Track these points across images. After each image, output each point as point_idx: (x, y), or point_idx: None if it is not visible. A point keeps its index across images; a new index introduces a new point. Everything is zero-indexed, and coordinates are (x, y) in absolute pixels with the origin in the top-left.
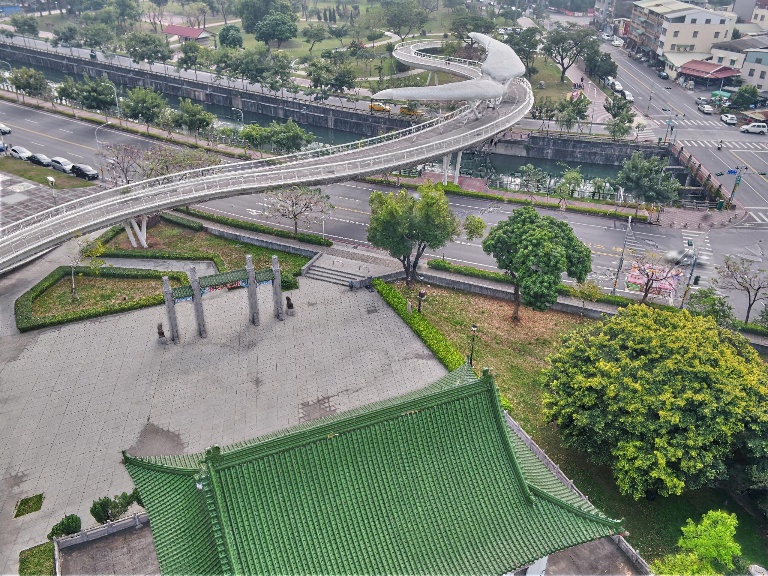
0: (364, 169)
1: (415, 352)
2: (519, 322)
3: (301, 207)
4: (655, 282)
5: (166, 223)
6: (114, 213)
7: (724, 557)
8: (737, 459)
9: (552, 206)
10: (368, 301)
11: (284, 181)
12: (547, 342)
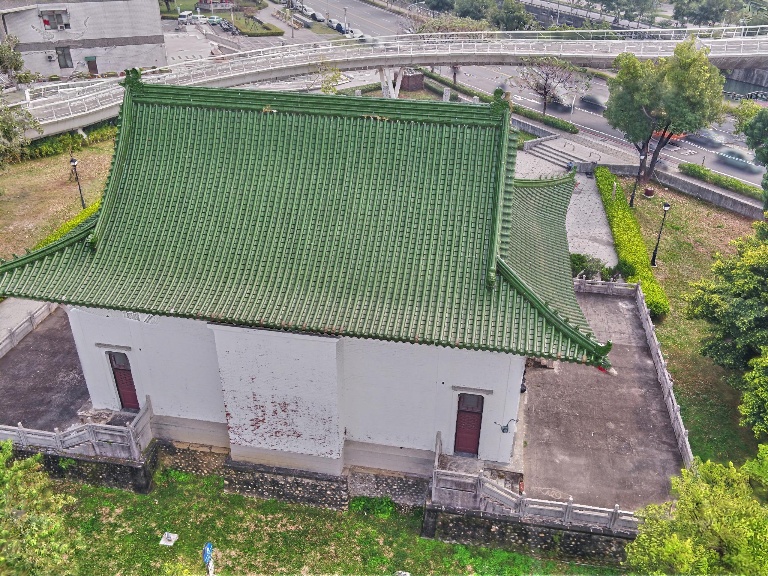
0: (648, 54)
1: (592, 234)
2: None
3: (555, 83)
4: None
5: (428, 91)
6: (368, 55)
7: None
8: None
9: None
10: None
11: (546, 52)
12: None
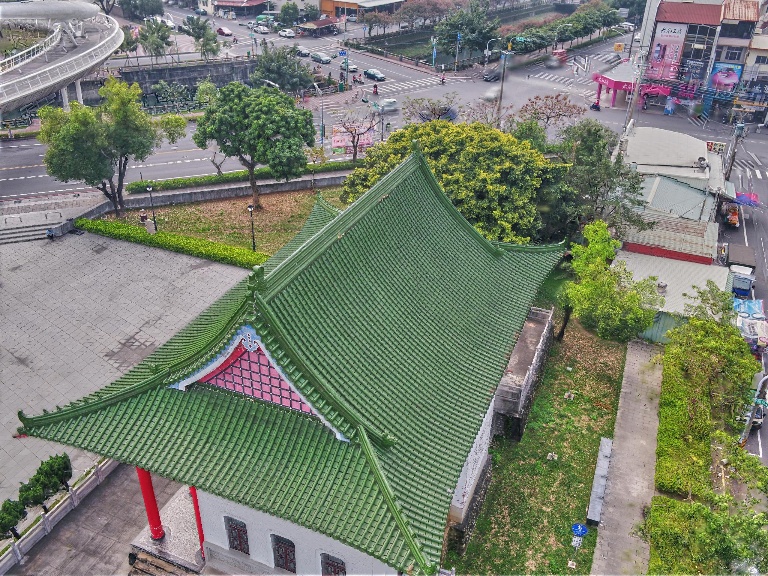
0: None
1: (187, 265)
2: (263, 209)
3: None
4: (363, 134)
5: None
6: None
7: (613, 253)
8: None
9: None
10: (86, 243)
11: None
12: (303, 215)
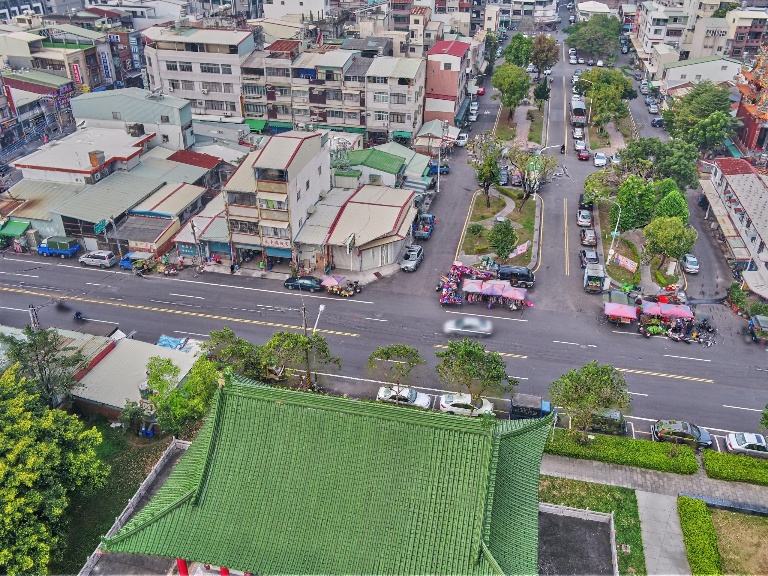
0: None
1: None
2: None
3: None
4: None
5: None
6: None
7: None
8: None
9: None
10: None
11: None
12: None
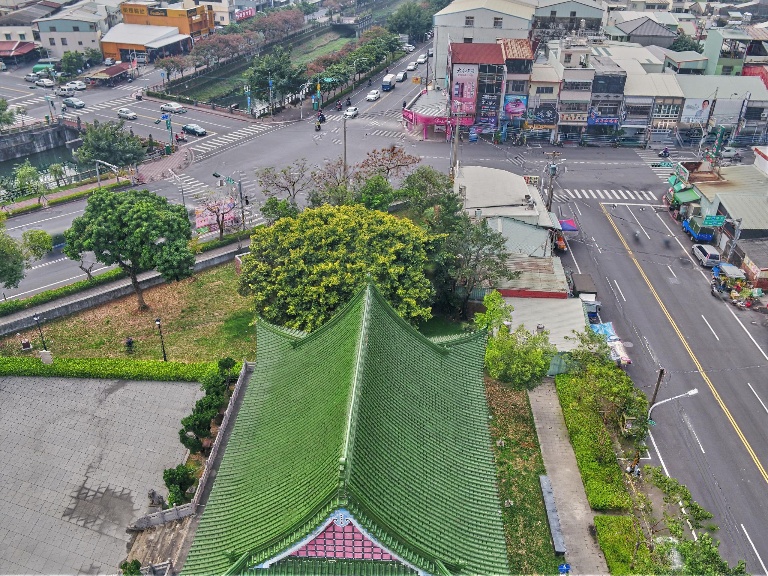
0: None
1: (101, 390)
2: (150, 309)
3: None
4: None
5: None
6: None
7: None
8: (427, 278)
9: (34, 208)
10: None
11: None
12: (193, 308)
